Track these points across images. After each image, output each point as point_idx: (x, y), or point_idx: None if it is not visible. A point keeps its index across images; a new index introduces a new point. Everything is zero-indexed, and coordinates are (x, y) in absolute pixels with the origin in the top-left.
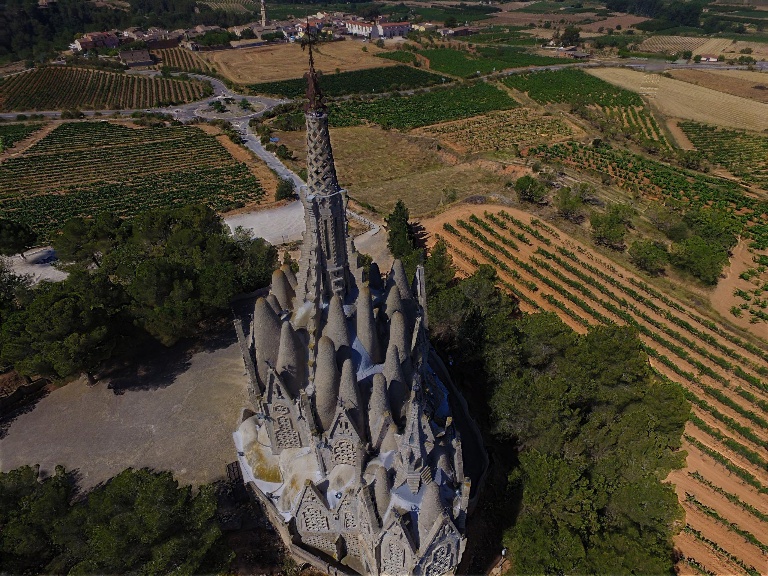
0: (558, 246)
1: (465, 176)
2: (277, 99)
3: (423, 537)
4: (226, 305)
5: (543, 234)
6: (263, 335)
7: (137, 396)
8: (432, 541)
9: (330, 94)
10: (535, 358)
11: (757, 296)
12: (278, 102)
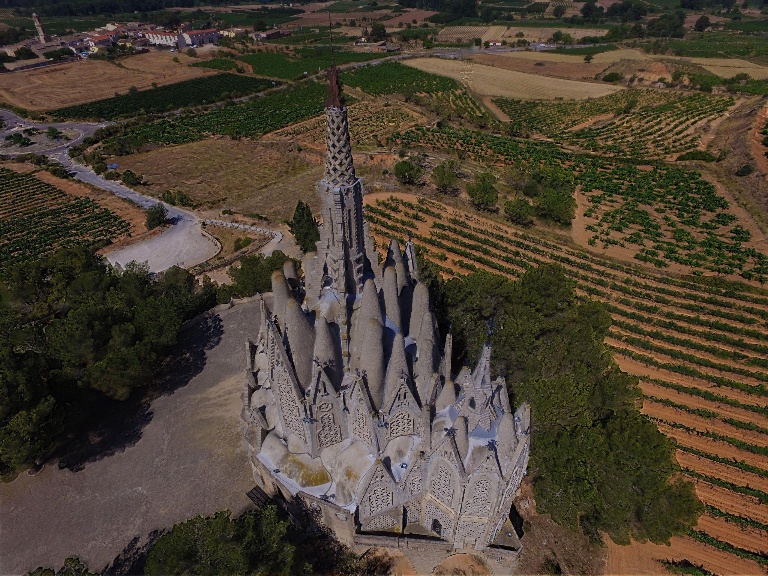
0: (449, 218)
1: None
2: (93, 123)
3: (505, 464)
4: (173, 340)
5: (432, 210)
6: (299, 338)
7: (103, 465)
8: (516, 462)
9: (156, 110)
10: (487, 310)
11: (600, 227)
12: (95, 126)
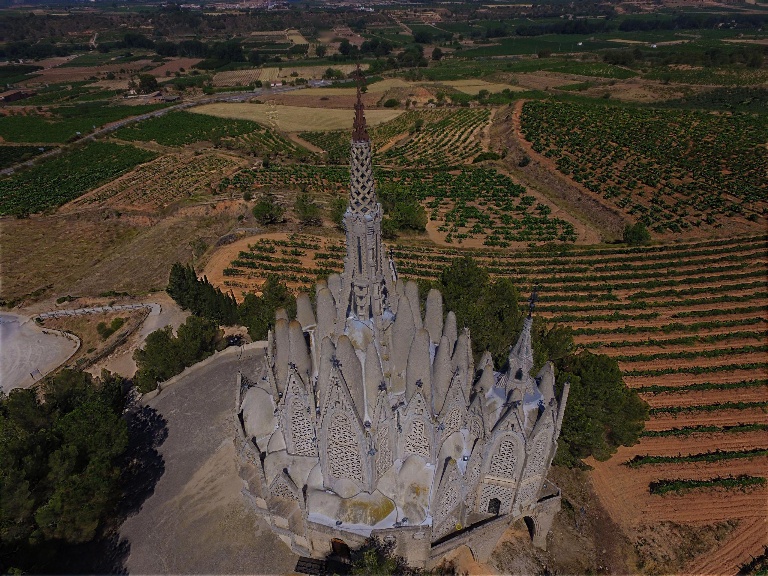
0: (327, 246)
1: (180, 228)
2: None
3: None
4: None
5: None
6: (353, 371)
7: None
8: None
9: None
10: None
11: None
12: None
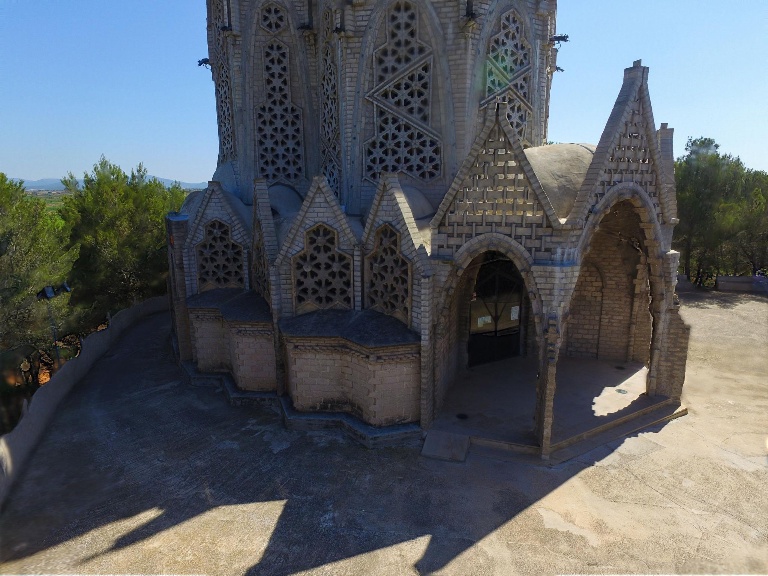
0: None
1: None
2: None
3: None
4: None
5: None
6: None
7: None
8: None
9: None
10: None
11: None
12: None
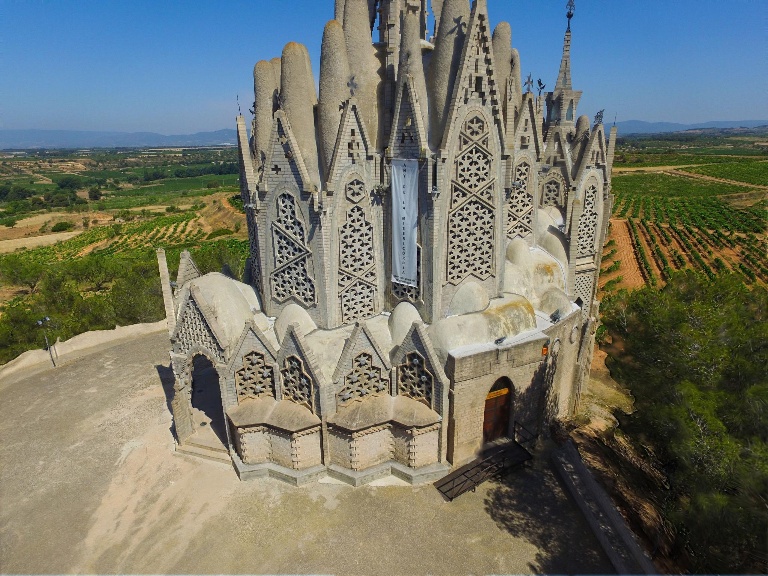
0: None
1: None
2: None
3: None
4: None
5: None
6: None
7: None
8: None
9: None
10: None
11: None
12: None
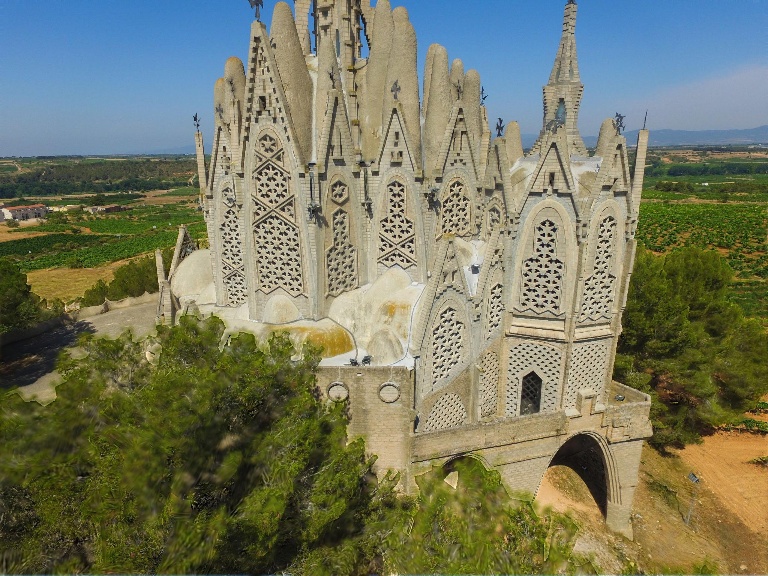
0: None
1: None
2: None
3: None
4: None
5: None
6: (293, 63)
7: None
8: None
9: None
10: None
11: None
12: None
